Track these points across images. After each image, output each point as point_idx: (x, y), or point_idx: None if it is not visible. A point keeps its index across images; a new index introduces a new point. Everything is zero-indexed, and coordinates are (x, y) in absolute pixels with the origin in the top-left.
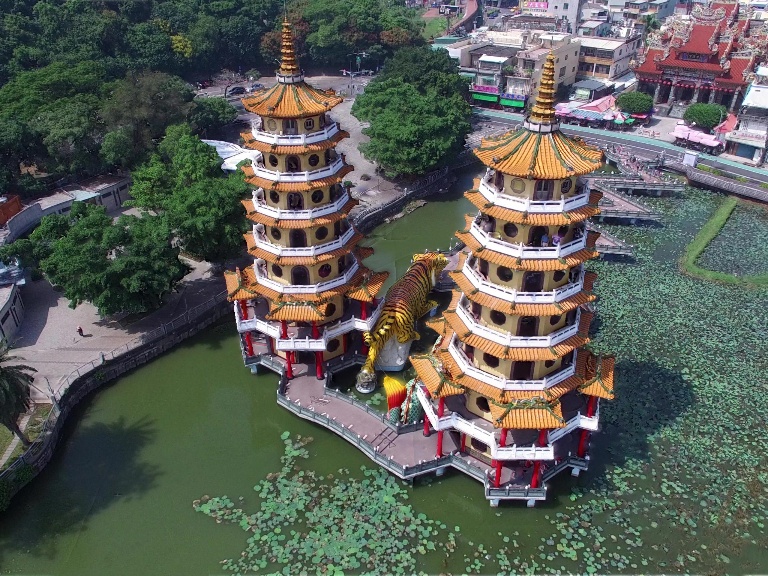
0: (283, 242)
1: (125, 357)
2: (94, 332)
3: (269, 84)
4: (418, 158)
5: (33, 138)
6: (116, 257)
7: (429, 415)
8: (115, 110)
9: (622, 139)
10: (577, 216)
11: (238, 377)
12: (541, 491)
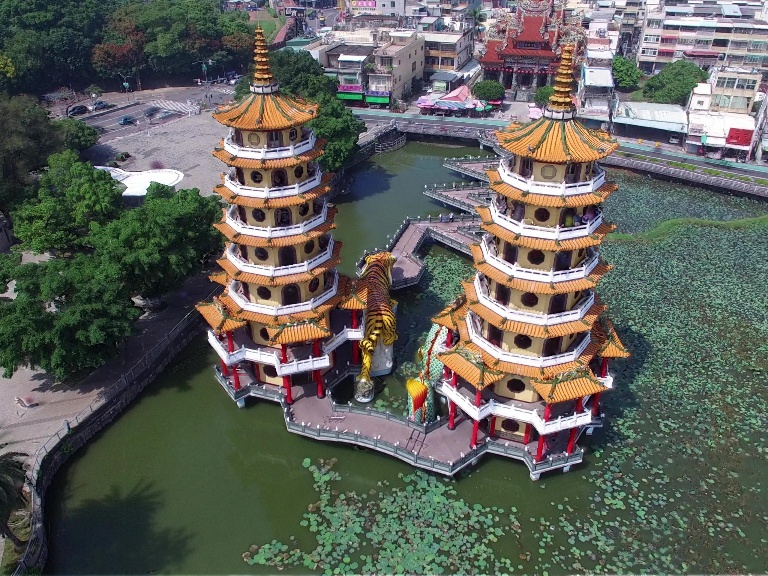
0: (271, 262)
1: (90, 420)
2: (39, 400)
3: (110, 100)
4: (324, 161)
5: None
6: (58, 309)
7: (465, 407)
8: None
9: (487, 125)
10: (603, 194)
11: (218, 415)
12: (578, 455)
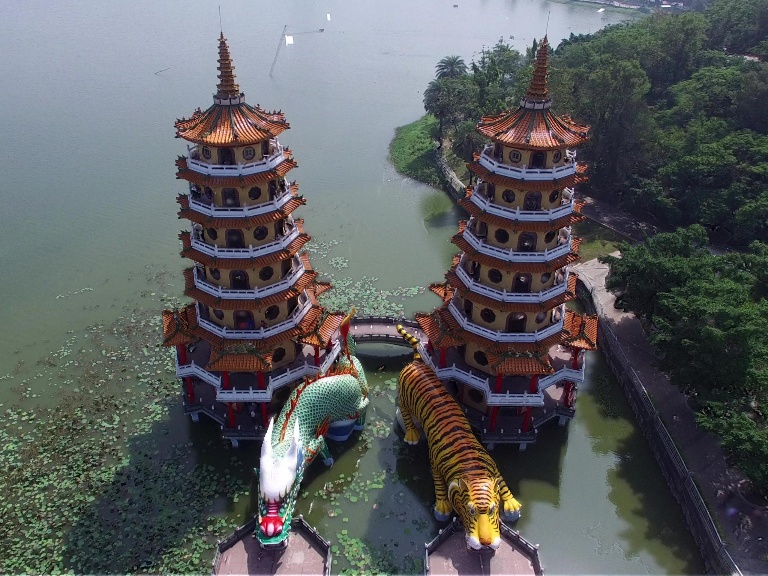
0: None
1: None
2: None
3: None
4: None
5: None
6: None
7: None
8: None
9: None
10: None
11: None
12: None
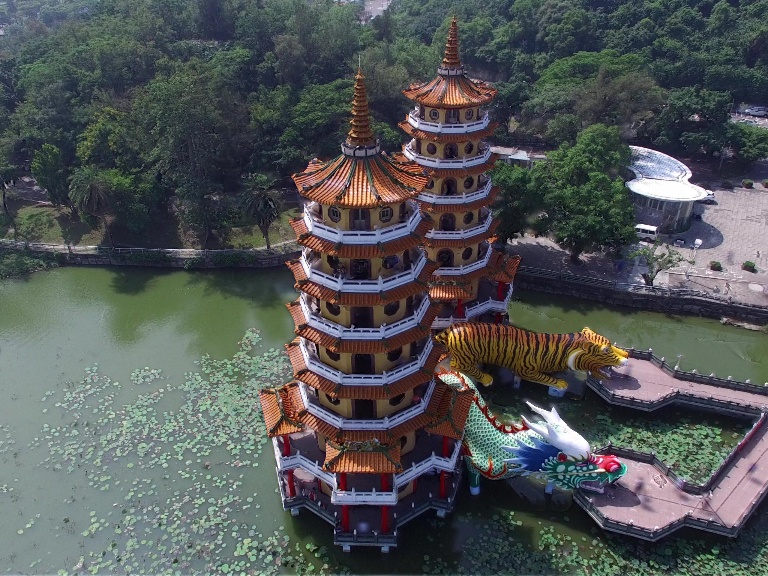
0: None
1: None
2: None
3: None
4: None
5: (519, 99)
6: None
7: None
8: (579, 96)
9: None
10: (317, 244)
11: None
12: None
